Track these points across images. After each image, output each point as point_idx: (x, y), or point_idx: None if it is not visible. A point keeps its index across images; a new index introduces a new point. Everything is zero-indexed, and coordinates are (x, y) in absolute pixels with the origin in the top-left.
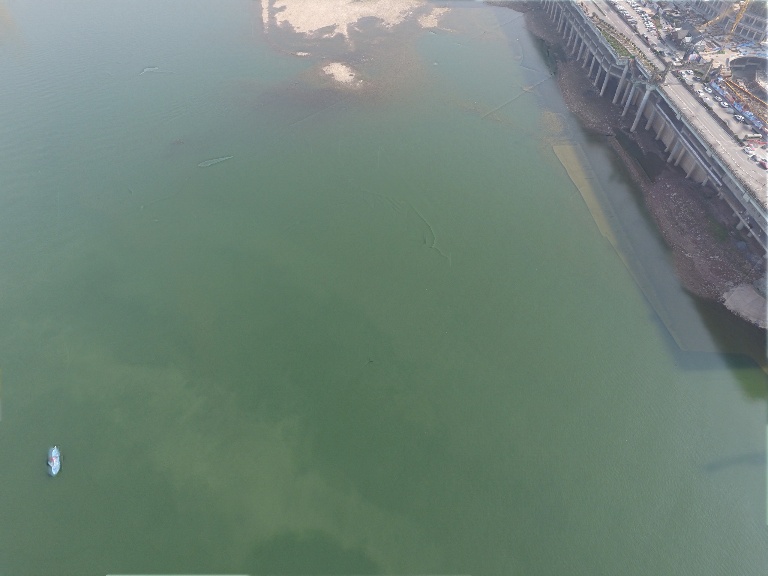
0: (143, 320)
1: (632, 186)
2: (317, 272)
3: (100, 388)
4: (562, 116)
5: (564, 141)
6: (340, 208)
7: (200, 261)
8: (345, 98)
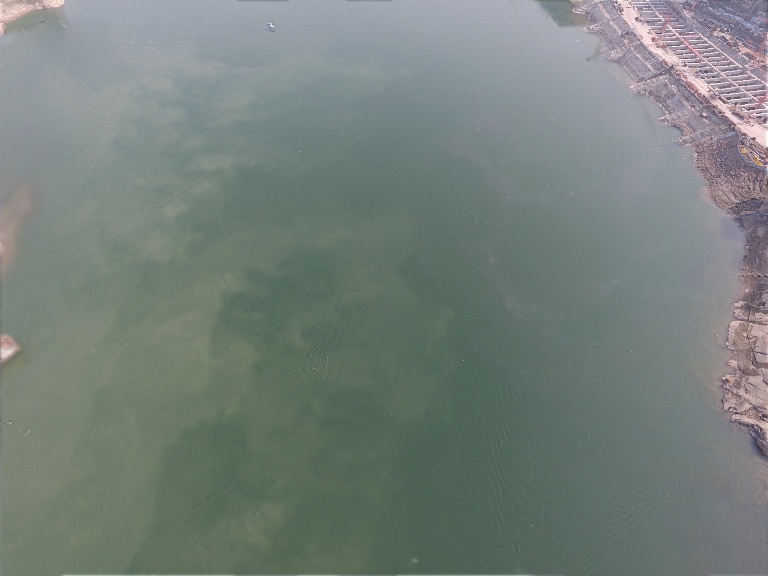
0: None
1: None
2: None
3: (281, 8)
4: None
5: None
6: None
7: None
8: None
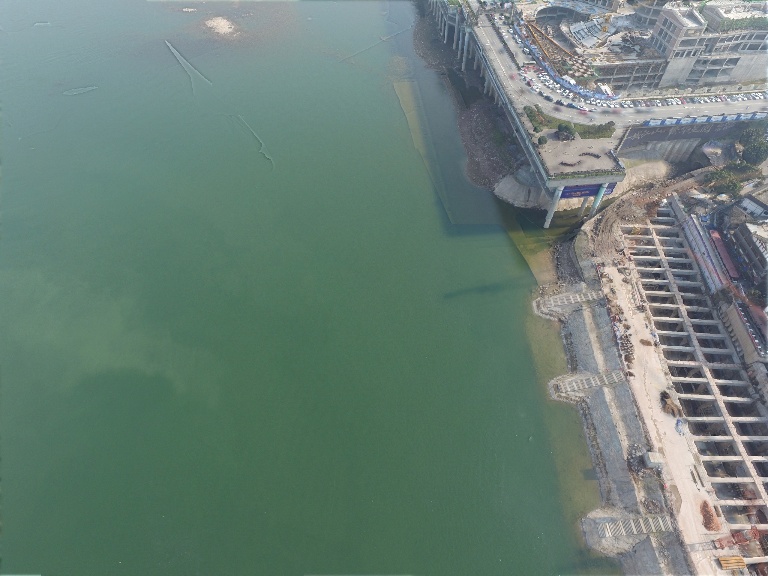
0: (6, 217)
1: (450, 112)
2: (171, 182)
3: None
4: (408, 60)
5: (404, 79)
6: (199, 133)
7: (67, 177)
8: (221, 46)
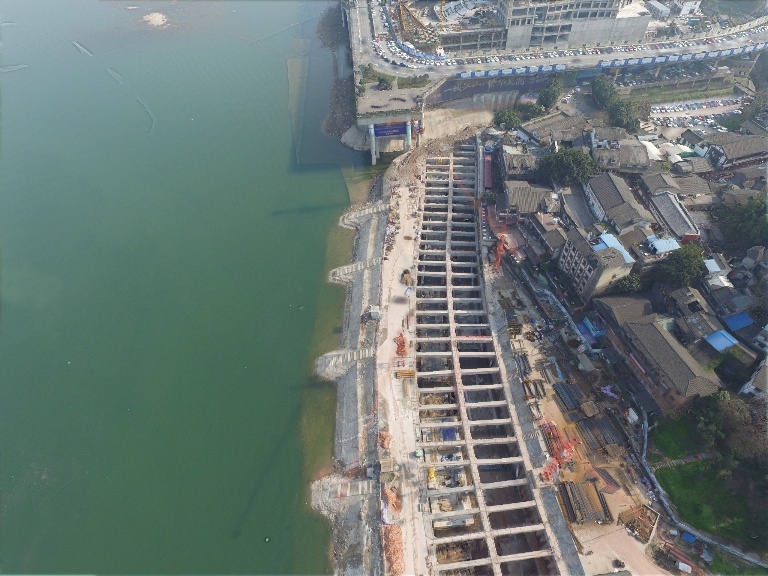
0: None
1: (328, 80)
2: (81, 140)
3: None
4: (308, 41)
5: (298, 56)
6: (113, 103)
7: None
8: (151, 36)
